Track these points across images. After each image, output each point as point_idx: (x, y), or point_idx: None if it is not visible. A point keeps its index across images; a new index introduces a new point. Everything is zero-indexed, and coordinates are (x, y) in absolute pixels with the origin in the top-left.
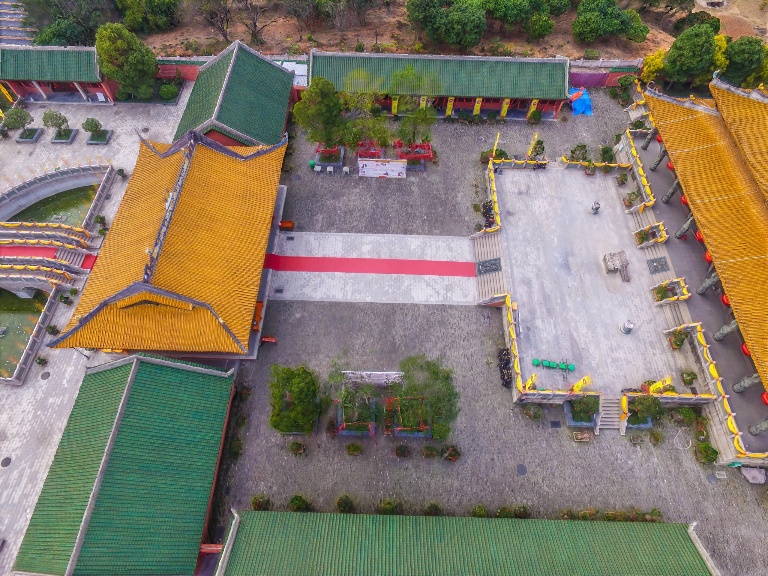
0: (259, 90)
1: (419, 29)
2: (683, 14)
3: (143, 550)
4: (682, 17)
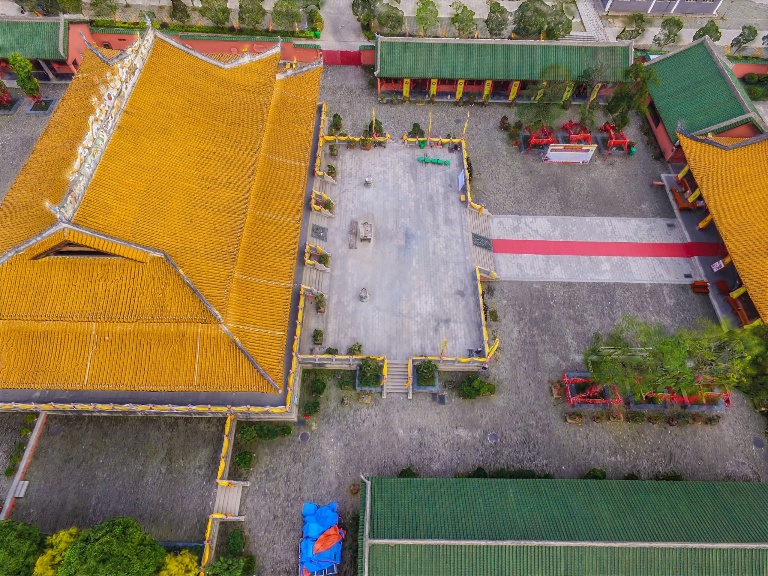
0: None
1: None
2: None
3: None
4: None
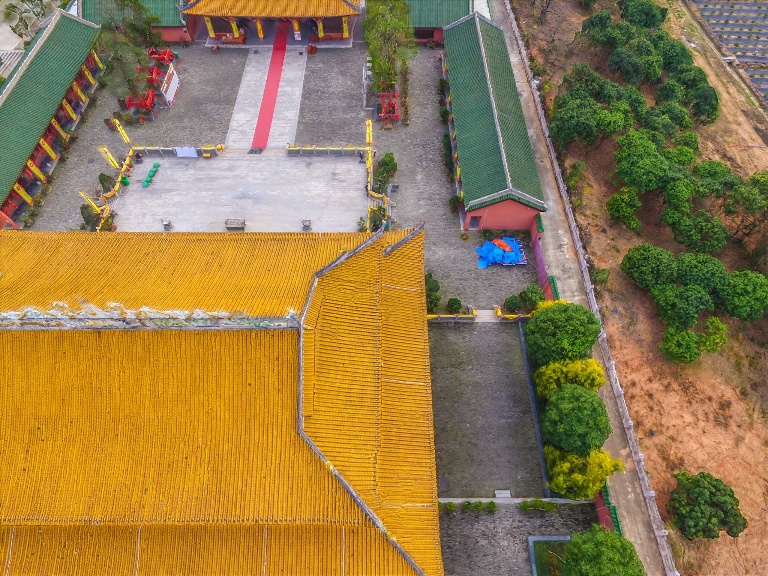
0: (430, 1)
1: (560, 90)
2: None
3: (93, 0)
4: None
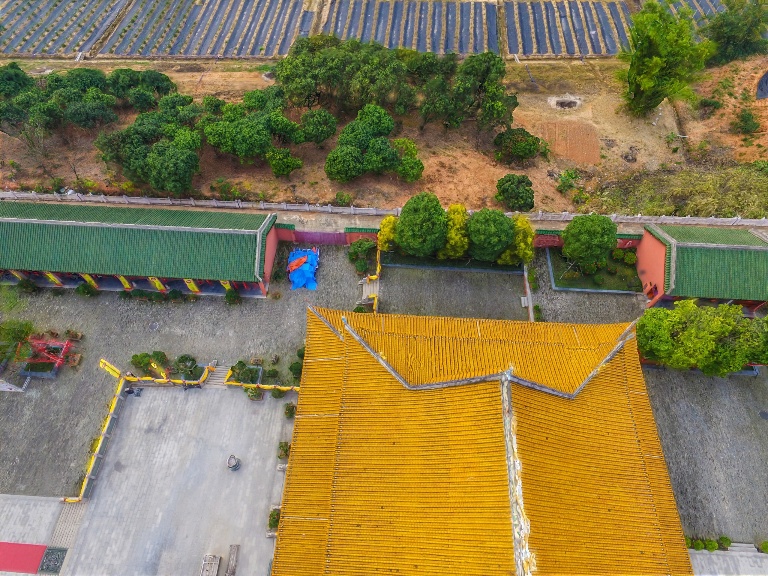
0: None
1: (115, 169)
2: (502, 128)
3: None
4: (501, 132)
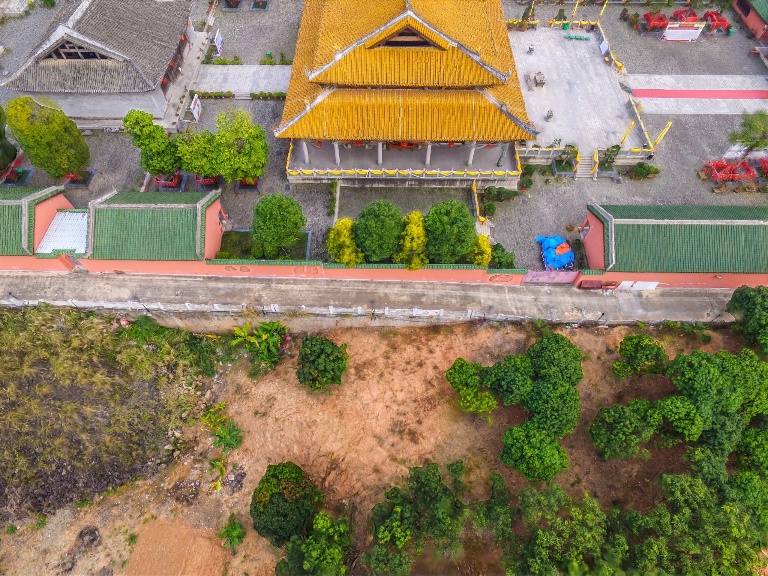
0: None
1: None
2: None
3: None
4: None
